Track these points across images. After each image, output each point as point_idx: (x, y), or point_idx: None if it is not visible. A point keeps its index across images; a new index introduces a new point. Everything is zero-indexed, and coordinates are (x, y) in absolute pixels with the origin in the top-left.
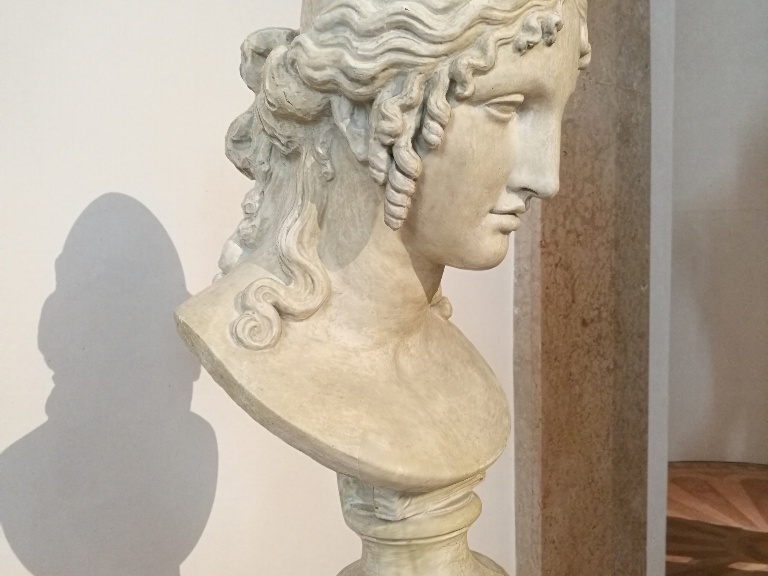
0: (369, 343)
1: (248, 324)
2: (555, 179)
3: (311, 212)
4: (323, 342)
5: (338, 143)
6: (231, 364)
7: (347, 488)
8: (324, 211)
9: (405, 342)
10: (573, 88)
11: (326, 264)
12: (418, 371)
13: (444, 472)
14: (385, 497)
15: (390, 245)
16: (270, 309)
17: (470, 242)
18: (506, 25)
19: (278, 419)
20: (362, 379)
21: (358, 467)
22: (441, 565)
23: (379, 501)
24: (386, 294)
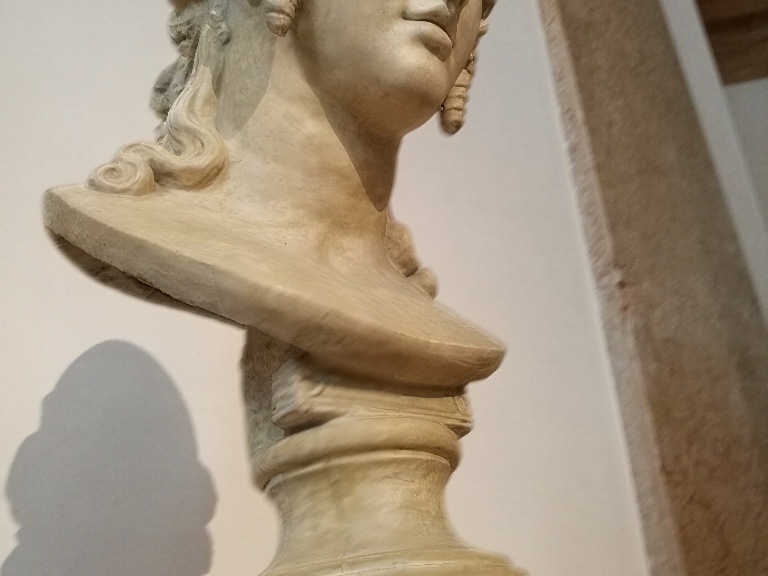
0: (278, 220)
1: (104, 165)
2: None
3: (204, 76)
4: (212, 210)
5: (234, 3)
6: (70, 197)
7: (255, 432)
8: (221, 77)
9: (337, 238)
10: None
11: (224, 134)
12: (356, 272)
13: (359, 314)
14: (282, 382)
15: (293, 88)
16: (137, 156)
17: (382, 51)
18: None
19: (110, 233)
20: (258, 240)
21: (213, 281)
22: (384, 507)
23: (276, 395)
24: (295, 153)
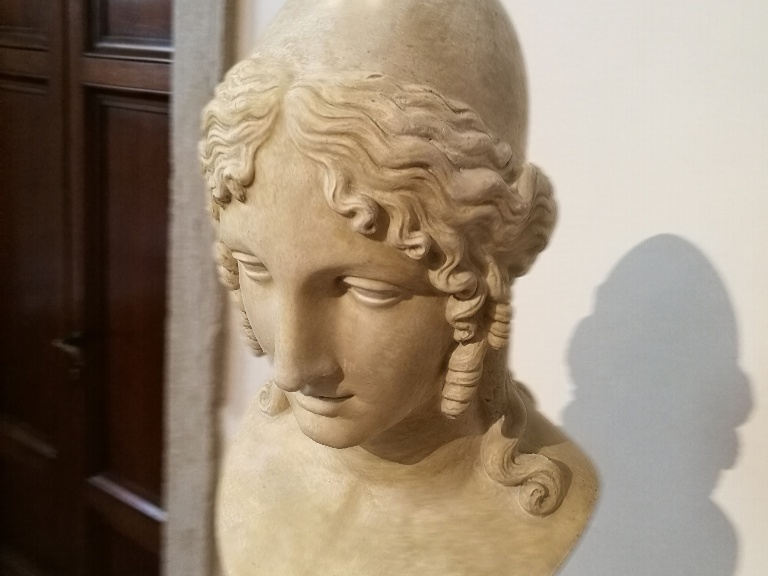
0: (329, 462)
1: (263, 387)
2: (279, 369)
3: None
4: None
5: None
6: (246, 411)
7: None
8: None
9: (367, 486)
10: (326, 259)
11: None
12: (369, 524)
13: None
14: None
15: None
16: None
17: None
18: (212, 173)
19: None
20: (298, 487)
21: None
22: None
23: None
24: None
